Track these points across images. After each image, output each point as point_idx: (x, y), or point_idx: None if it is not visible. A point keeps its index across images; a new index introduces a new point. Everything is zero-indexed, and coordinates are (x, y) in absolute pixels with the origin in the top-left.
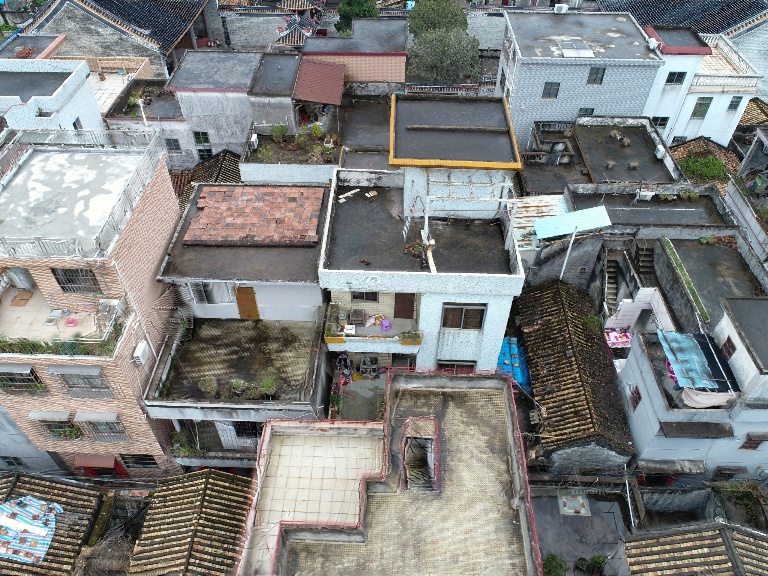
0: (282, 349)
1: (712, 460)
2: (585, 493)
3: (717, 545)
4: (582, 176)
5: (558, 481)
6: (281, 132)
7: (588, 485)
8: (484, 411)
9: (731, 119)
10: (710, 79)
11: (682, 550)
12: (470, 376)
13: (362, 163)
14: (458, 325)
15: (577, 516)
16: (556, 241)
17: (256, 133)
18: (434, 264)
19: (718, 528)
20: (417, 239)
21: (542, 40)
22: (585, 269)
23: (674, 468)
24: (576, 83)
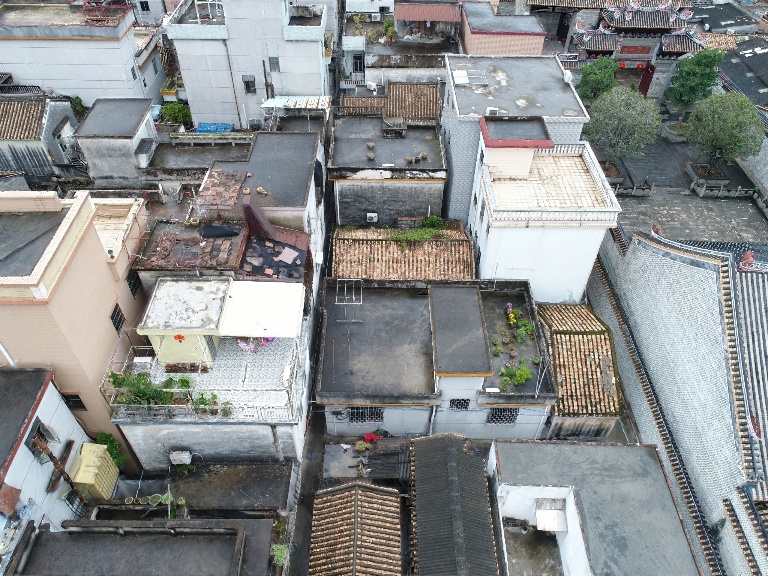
0: None
1: None
2: None
3: None
4: None
5: None
6: (387, 22)
7: None
8: None
9: None
10: None
11: None
12: (121, 20)
13: None
14: None
15: None
16: None
17: None
18: (197, 20)
19: None
20: None
21: (492, 68)
22: None
23: None
24: None
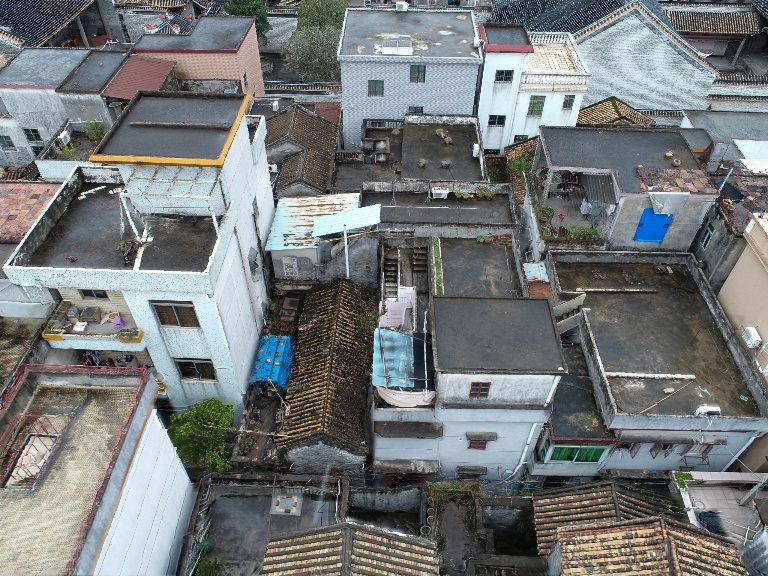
0: (11, 346)
1: (448, 460)
2: (301, 493)
3: (336, 545)
4: (395, 174)
5: (271, 480)
6: (94, 129)
7: (302, 484)
8: (123, 409)
9: (568, 118)
10: (538, 77)
11: (307, 550)
12: (109, 374)
13: None
14: (176, 323)
15: (286, 516)
16: (333, 239)
17: (74, 130)
18: (140, 261)
19: (341, 528)
20: (136, 236)
21: (370, 38)
22: (370, 268)
23: (408, 468)
24: (399, 81)
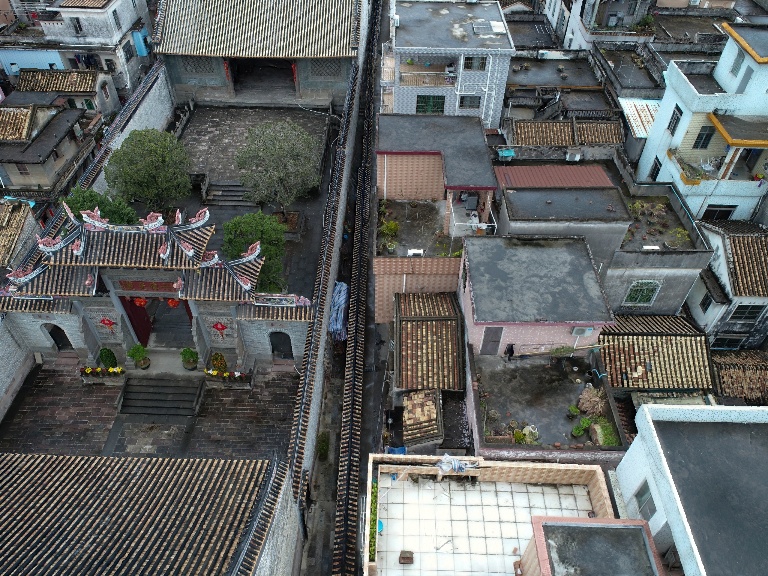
0: None
1: None
2: None
3: None
4: (571, 94)
5: None
6: None
7: None
8: None
9: None
10: None
11: None
12: None
13: (743, 134)
14: None
15: None
16: None
17: None
18: None
19: None
20: None
21: (465, 39)
22: None
23: None
24: None
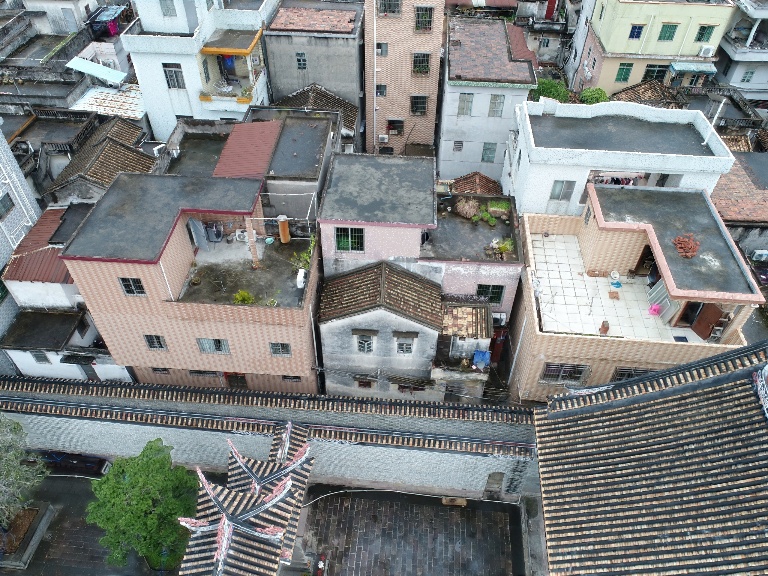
0: None
1: None
2: None
3: None
4: None
5: None
6: None
7: None
8: None
9: None
10: None
11: None
12: None
13: (237, 45)
14: None
15: None
16: None
17: None
18: None
19: None
20: (223, 2)
21: None
22: None
23: None
24: None
